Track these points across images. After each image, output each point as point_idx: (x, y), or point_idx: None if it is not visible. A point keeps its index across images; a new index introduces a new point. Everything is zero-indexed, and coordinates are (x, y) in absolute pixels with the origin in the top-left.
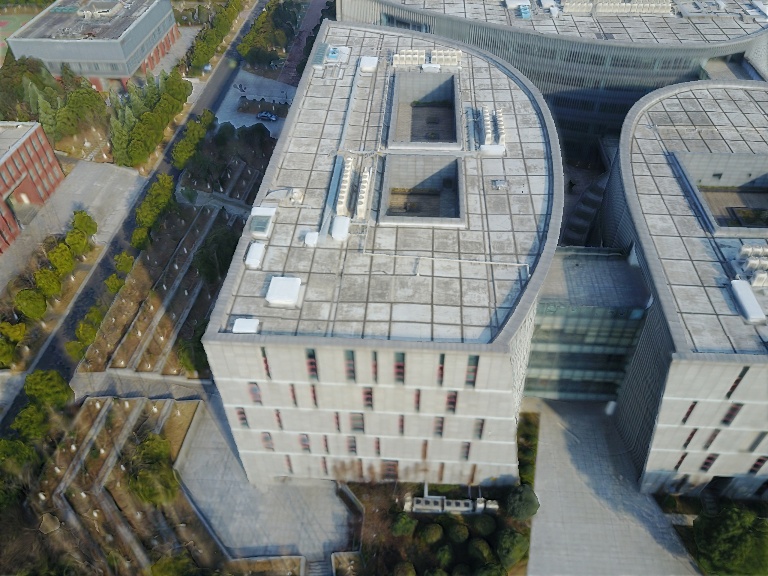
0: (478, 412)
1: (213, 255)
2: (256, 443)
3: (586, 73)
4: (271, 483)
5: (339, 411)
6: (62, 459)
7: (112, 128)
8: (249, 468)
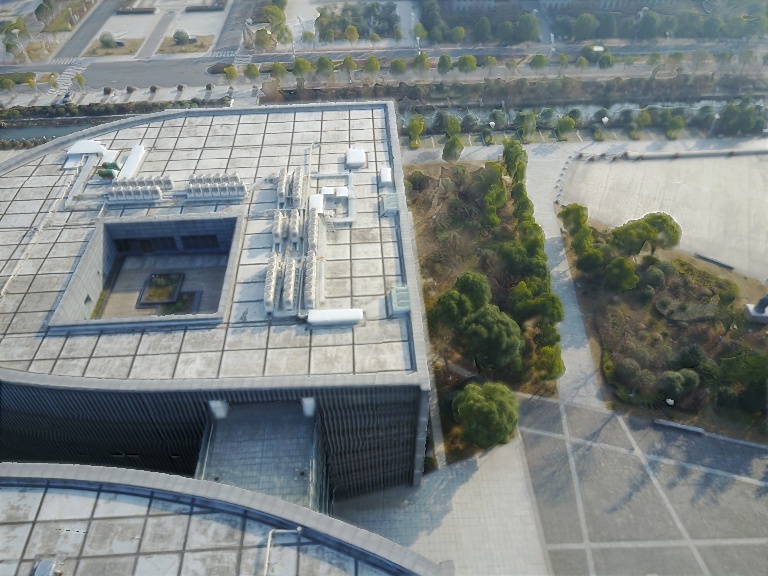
0: None
1: None
2: None
3: None
4: None
5: None
6: None
7: None
8: None
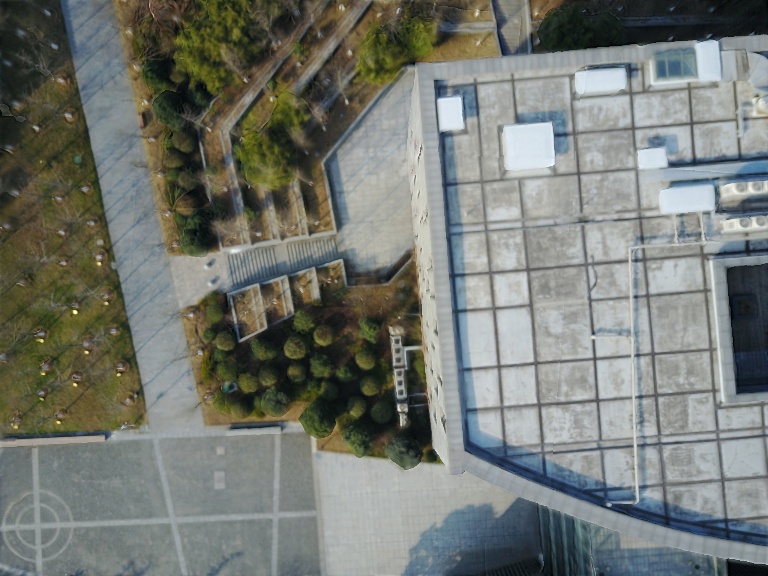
0: None
1: None
2: None
3: None
4: None
5: None
6: None
7: None
8: None
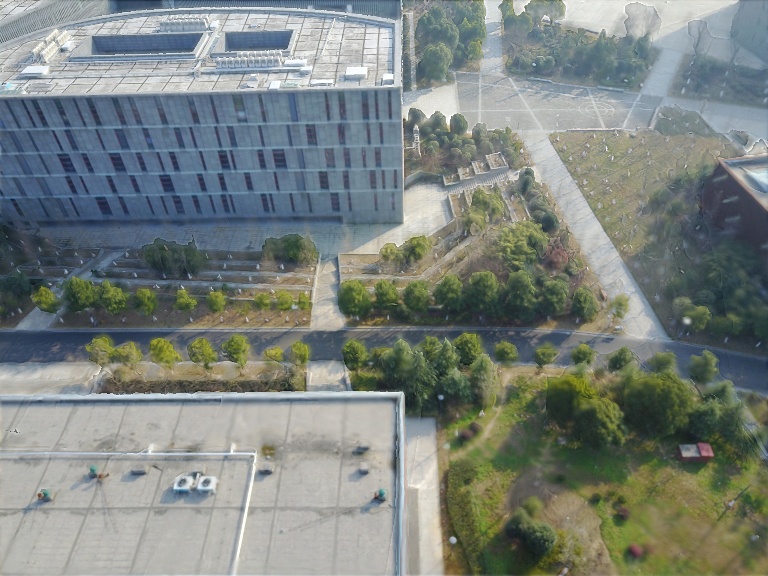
0: None
1: (193, 241)
2: None
3: None
4: None
5: None
6: None
7: None
8: None
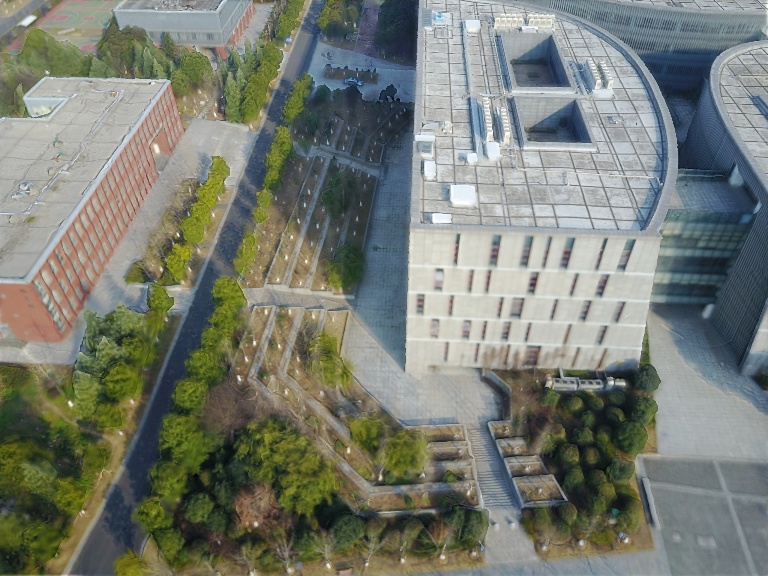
0: (622, 295)
1: (341, 193)
2: (424, 330)
3: (658, 38)
4: (424, 372)
5: (504, 296)
6: (247, 352)
7: (228, 87)
8: (410, 357)
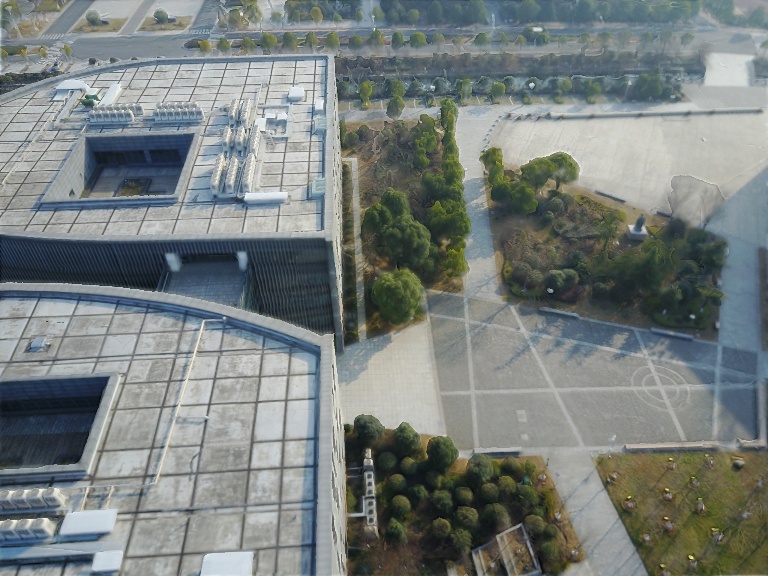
0: None
1: None
2: None
3: None
4: None
5: None
6: None
7: None
8: None
